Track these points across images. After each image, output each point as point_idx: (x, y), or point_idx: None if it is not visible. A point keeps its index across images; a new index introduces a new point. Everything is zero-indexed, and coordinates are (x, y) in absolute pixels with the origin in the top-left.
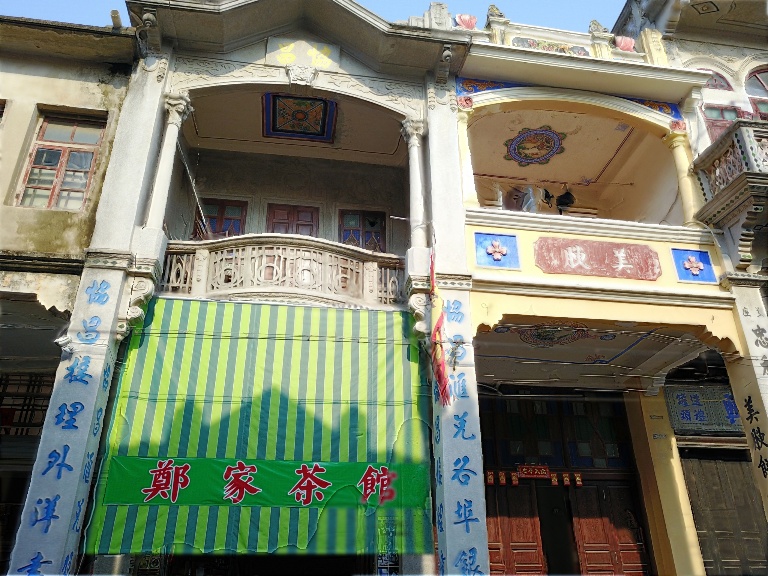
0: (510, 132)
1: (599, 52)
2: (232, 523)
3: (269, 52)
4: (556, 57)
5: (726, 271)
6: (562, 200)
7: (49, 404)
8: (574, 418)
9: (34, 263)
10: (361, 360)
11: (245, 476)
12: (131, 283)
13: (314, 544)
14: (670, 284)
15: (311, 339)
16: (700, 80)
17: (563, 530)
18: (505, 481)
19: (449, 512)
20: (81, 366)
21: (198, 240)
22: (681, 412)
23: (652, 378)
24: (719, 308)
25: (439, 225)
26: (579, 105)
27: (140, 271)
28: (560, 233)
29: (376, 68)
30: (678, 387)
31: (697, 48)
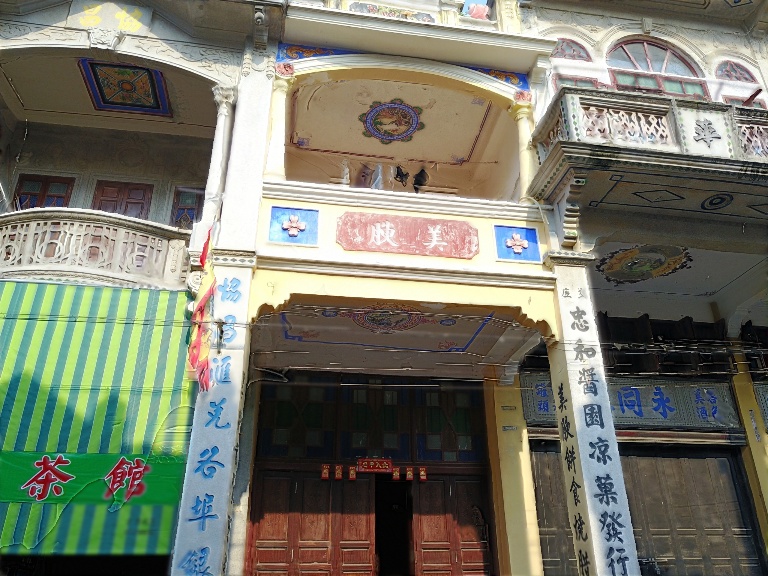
0: (360, 106)
1: (445, 19)
2: None
3: (71, 14)
4: (383, 21)
5: (551, 249)
6: (417, 178)
7: None
8: (426, 409)
9: None
10: (132, 343)
11: None
12: None
13: (133, 542)
14: (486, 263)
15: (78, 320)
16: (544, 48)
17: (401, 527)
18: (341, 475)
19: (185, 508)
20: None
21: None
22: (538, 403)
23: (503, 366)
24: (539, 289)
25: (230, 198)
26: (418, 74)
27: None
28: (370, 208)
29: (191, 32)
30: (537, 376)
31: (558, 17)
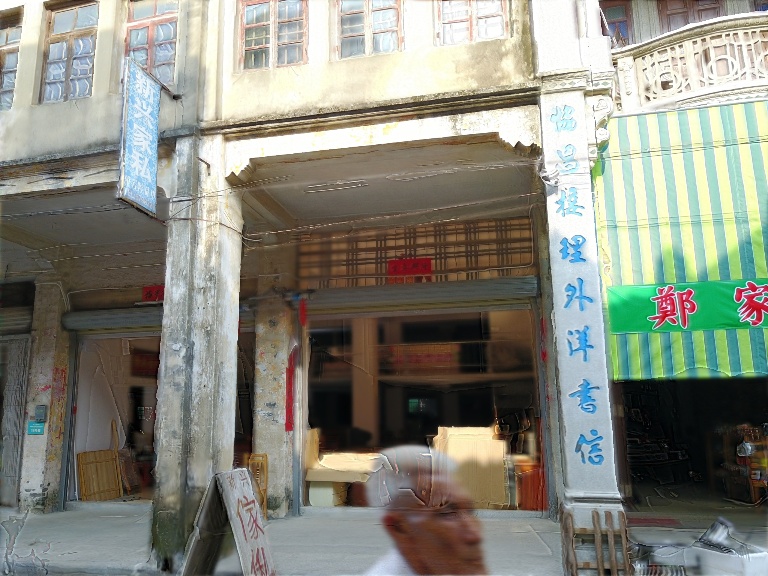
0: None
1: None
2: (756, 346)
3: None
4: None
5: None
6: None
7: (549, 240)
8: None
9: (490, 100)
10: None
11: (759, 297)
12: (591, 103)
13: None
14: None
15: None
16: None
17: None
18: None
19: None
20: (570, 198)
21: (620, 47)
22: None
23: None
24: None
25: None
26: None
27: (599, 88)
28: None
29: None
30: None
31: None
